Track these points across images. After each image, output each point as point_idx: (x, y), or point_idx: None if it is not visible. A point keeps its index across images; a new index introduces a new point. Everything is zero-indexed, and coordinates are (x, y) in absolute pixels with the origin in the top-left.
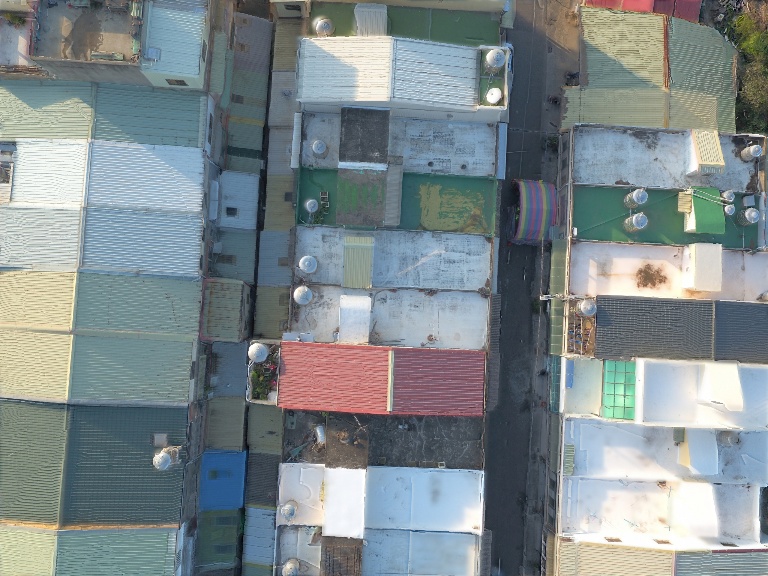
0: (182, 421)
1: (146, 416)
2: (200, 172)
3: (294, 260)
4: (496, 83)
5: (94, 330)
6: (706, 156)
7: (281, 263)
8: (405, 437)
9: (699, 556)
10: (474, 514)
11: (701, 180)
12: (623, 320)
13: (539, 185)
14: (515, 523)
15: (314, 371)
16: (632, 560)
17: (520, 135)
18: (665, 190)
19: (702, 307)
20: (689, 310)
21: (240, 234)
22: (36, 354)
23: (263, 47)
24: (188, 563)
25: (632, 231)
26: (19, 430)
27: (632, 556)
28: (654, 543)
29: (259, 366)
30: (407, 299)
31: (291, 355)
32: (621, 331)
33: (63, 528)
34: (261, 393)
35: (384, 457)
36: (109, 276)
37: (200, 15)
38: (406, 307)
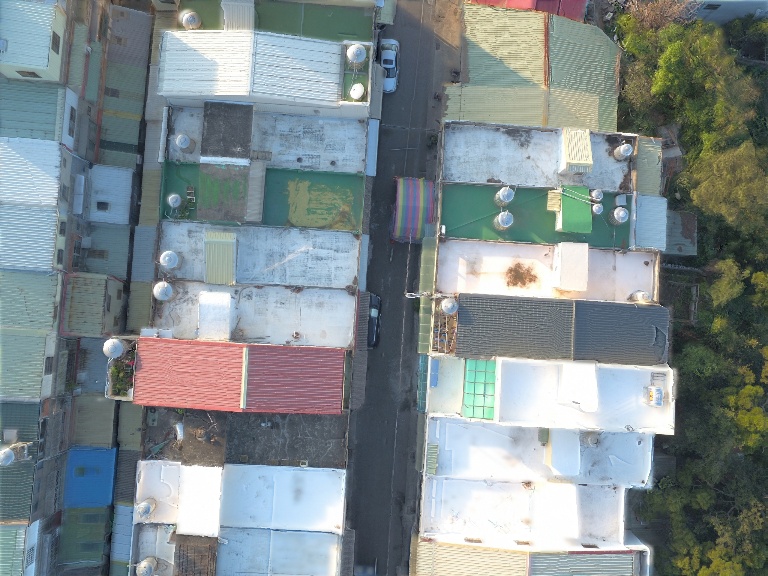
0: (34, 417)
1: None
2: (56, 165)
3: (157, 255)
4: (361, 79)
5: None
6: (577, 155)
7: None
8: (268, 435)
9: (555, 557)
10: (336, 513)
11: (574, 179)
12: (490, 319)
13: (418, 182)
14: (393, 523)
15: (176, 368)
16: (487, 561)
17: (405, 132)
18: (537, 188)
19: (562, 306)
20: (553, 309)
21: (112, 229)
22: None
23: (141, 40)
24: (44, 561)
25: (501, 229)
26: None
27: (487, 557)
28: (512, 544)
29: (119, 362)
30: (273, 296)
31: (147, 351)
32: (488, 330)
33: None
34: (121, 389)
35: (246, 455)
36: None
37: (50, 6)
38: (272, 304)
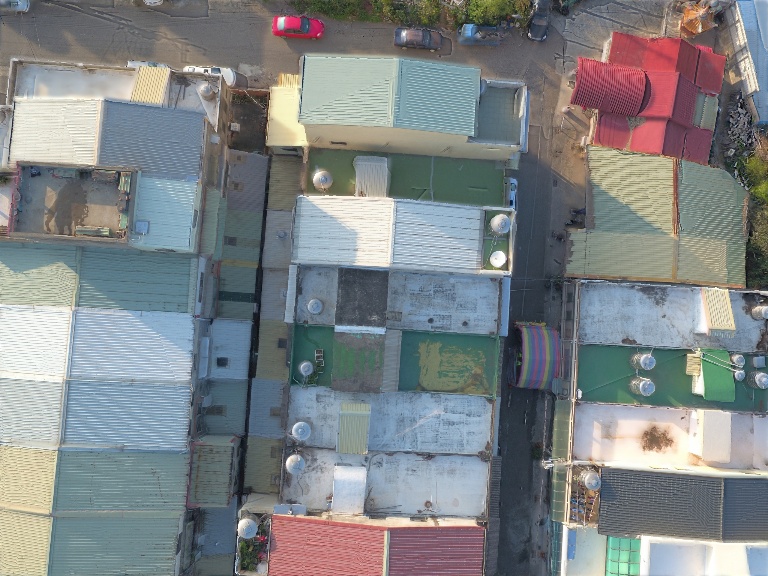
0: None
1: None
2: (189, 339)
3: (287, 423)
4: (500, 244)
5: (75, 511)
6: (716, 317)
7: (273, 413)
8: None
9: None
10: None
11: (710, 339)
12: (628, 488)
13: (542, 332)
14: None
15: None
16: None
17: (523, 272)
18: (673, 350)
19: (711, 485)
20: None
21: (231, 384)
22: (14, 535)
23: (257, 185)
24: None
25: (638, 394)
26: None
27: None
28: None
29: None
30: (404, 463)
31: (282, 531)
32: (626, 499)
33: None
34: (250, 563)
35: None
36: (92, 453)
37: (191, 184)
38: (403, 471)
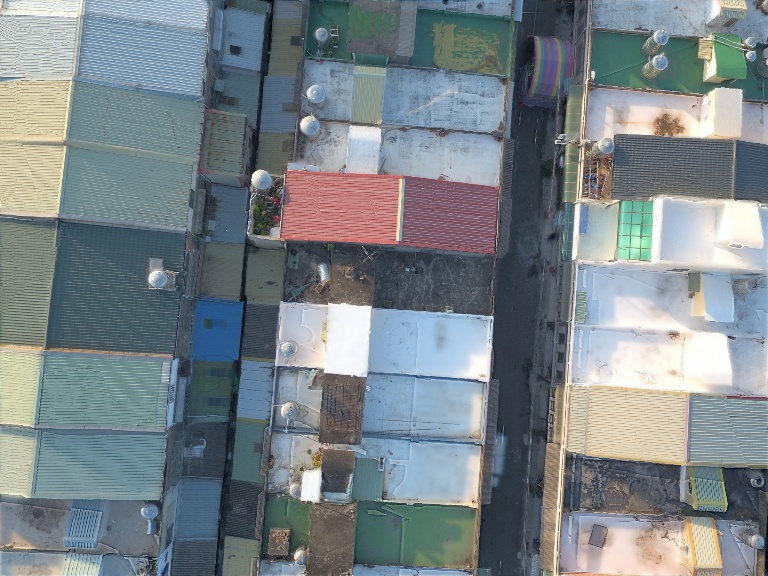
0: (180, 247)
1: (142, 239)
2: None
3: (301, 92)
4: None
5: (89, 142)
6: (728, 3)
7: (285, 108)
8: (412, 281)
9: (714, 401)
10: (482, 362)
11: (721, 31)
12: (640, 167)
13: (554, 40)
14: (520, 390)
15: (319, 208)
16: (646, 403)
17: None
18: (685, 39)
19: (723, 147)
20: (708, 155)
21: (243, 75)
22: (26, 167)
23: None
24: (181, 404)
25: (651, 78)
26: (5, 260)
27: (646, 399)
28: None
29: (261, 200)
30: (417, 139)
31: (296, 184)
32: (637, 178)
33: (50, 349)
34: (263, 229)
35: (390, 300)
36: (106, 87)
37: None
38: (416, 147)
